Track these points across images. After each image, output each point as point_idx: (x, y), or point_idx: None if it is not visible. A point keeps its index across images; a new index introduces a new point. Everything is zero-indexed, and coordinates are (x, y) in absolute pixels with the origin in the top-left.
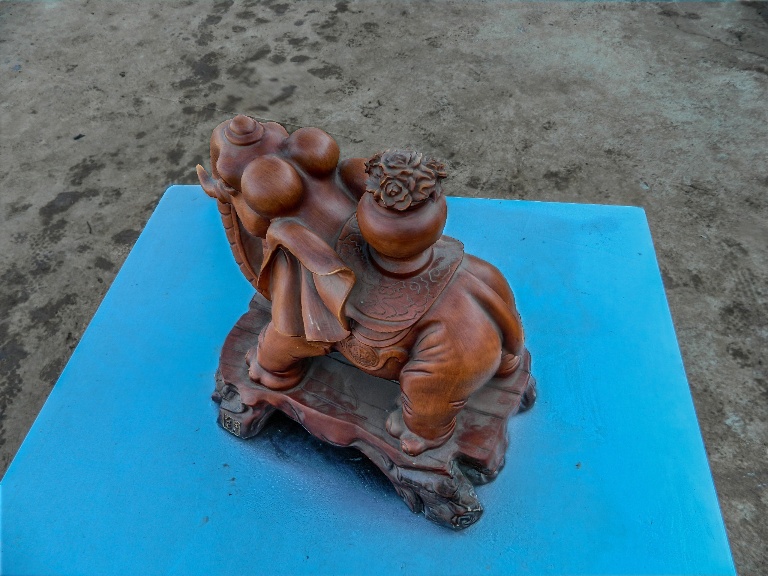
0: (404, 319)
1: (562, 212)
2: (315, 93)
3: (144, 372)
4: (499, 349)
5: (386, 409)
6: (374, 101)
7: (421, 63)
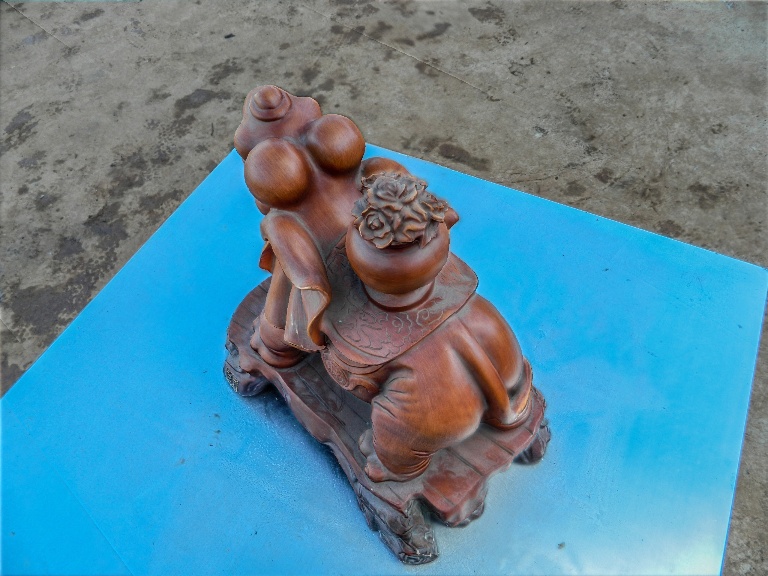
0: (376, 354)
1: (665, 250)
2: (468, 36)
3: (179, 299)
4: (475, 416)
5: (368, 421)
6: (527, 58)
7: (595, 24)
